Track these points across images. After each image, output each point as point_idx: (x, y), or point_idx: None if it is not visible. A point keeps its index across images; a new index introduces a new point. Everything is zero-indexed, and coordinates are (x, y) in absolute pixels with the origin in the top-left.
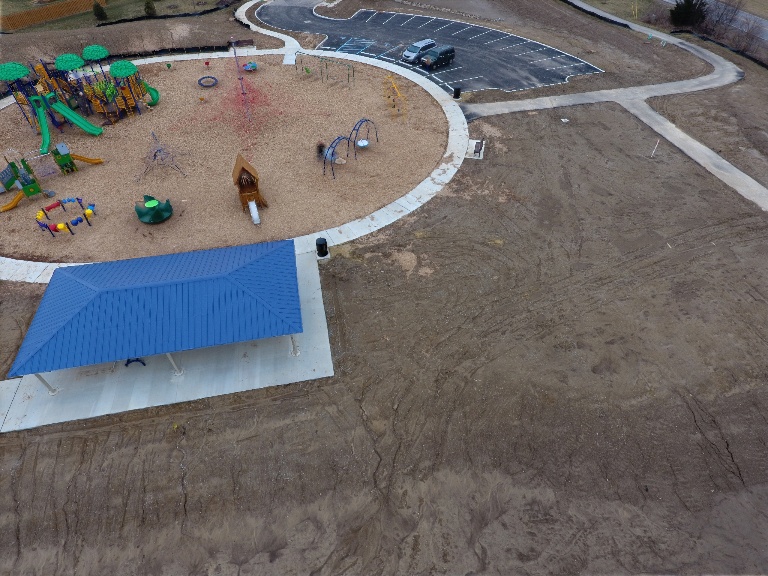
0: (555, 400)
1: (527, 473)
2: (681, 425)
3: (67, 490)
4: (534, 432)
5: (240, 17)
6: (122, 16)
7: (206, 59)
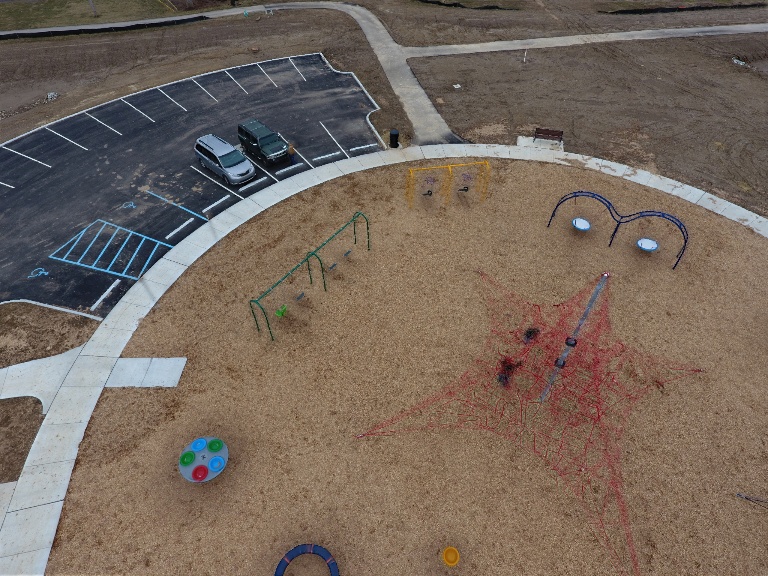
0: None
1: None
2: None
3: None
4: None
5: None
6: None
7: None
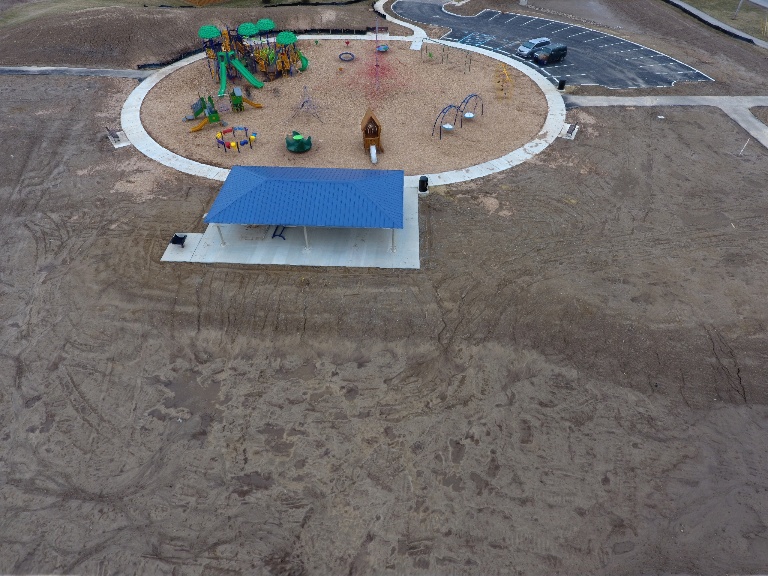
0: (593, 313)
1: (558, 356)
2: (700, 349)
3: (230, 301)
4: (570, 331)
5: (378, 9)
6: (282, 1)
7: (346, 40)
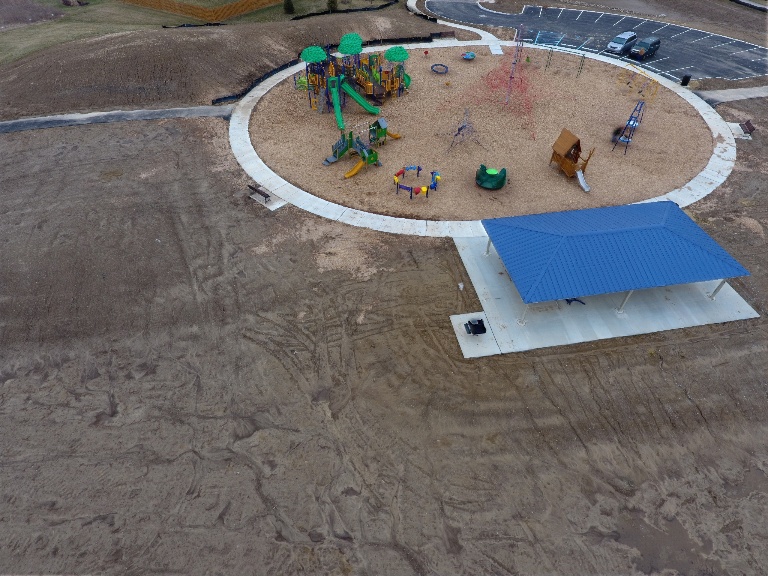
0: None
1: None
2: None
3: (594, 399)
4: None
5: None
6: (306, 10)
7: (418, 49)
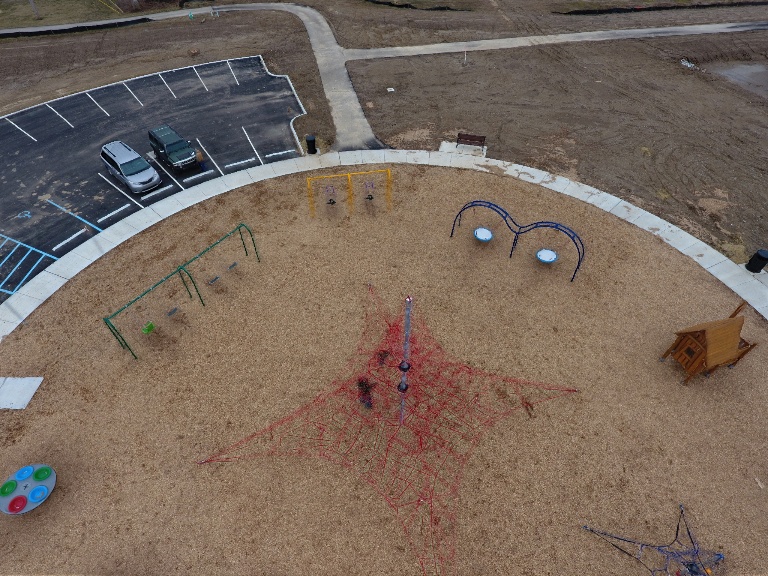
0: None
1: None
2: None
3: None
4: None
5: None
6: None
7: None
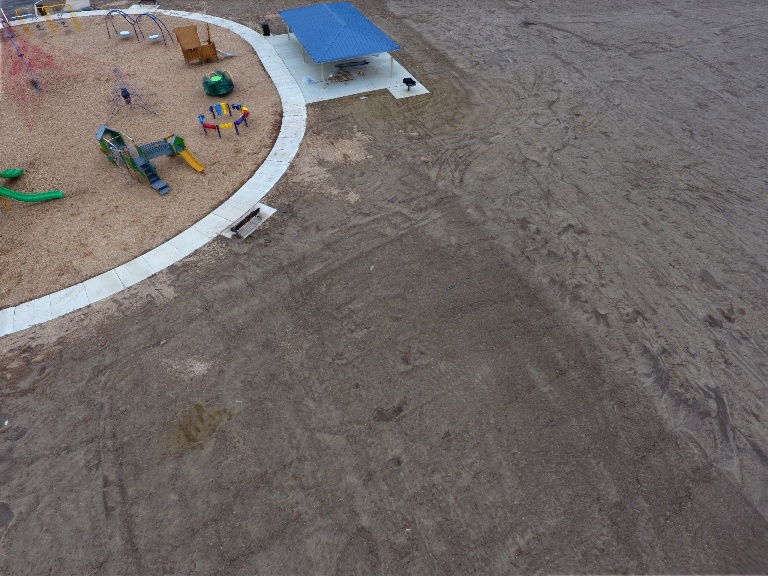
0: None
1: None
2: None
3: None
4: None
5: None
6: None
7: None
